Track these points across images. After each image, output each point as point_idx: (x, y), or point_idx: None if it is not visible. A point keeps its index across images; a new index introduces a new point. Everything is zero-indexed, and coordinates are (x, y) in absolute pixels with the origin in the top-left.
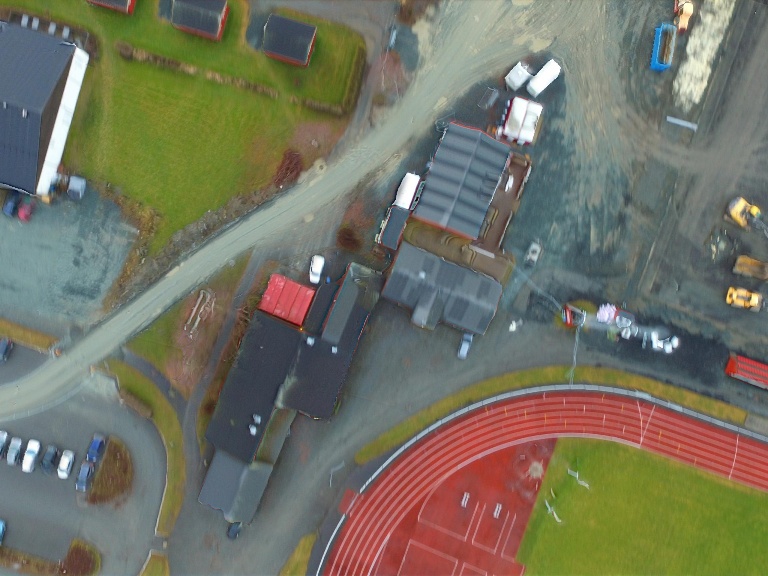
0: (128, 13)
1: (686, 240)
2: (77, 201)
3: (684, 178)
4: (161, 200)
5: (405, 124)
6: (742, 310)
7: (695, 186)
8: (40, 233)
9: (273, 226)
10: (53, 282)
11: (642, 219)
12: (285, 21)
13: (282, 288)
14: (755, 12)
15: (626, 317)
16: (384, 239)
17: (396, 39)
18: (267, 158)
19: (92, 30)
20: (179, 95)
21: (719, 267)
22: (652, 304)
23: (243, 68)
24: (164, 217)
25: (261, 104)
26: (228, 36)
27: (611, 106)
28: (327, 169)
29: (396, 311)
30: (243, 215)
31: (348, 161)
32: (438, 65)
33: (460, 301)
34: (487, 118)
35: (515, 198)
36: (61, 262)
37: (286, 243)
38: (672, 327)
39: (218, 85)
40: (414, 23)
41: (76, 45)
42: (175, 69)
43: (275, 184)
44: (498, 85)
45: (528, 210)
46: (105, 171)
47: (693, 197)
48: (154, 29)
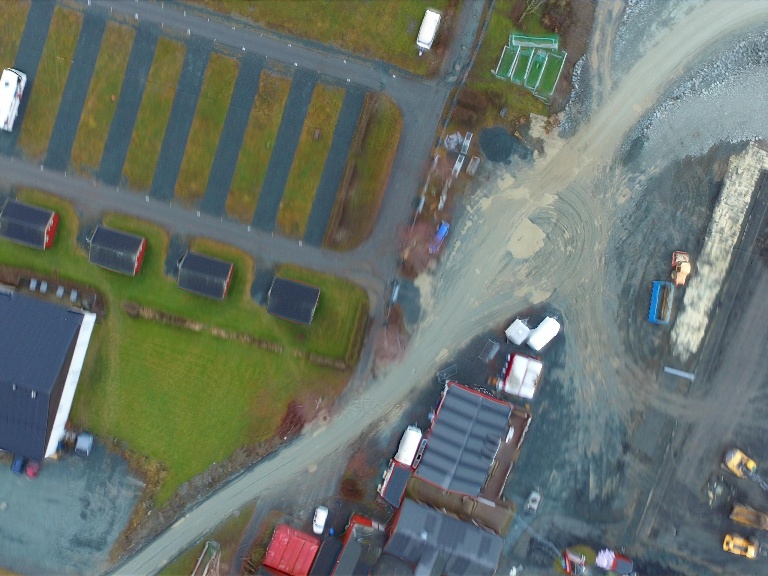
0: (135, 275)
1: (684, 486)
2: (84, 457)
3: (682, 426)
4: (167, 454)
5: (407, 375)
6: (739, 556)
7: (692, 434)
8: (48, 487)
9: (277, 476)
10: (61, 535)
11: (640, 466)
12: (289, 284)
13: (286, 544)
14: (751, 264)
15: (625, 567)
16: (387, 497)
17: (398, 293)
18: (271, 410)
19: (99, 288)
20: (185, 351)
21: (716, 512)
22: (650, 549)
23: (248, 323)
24: (170, 470)
25: (265, 358)
26: (233, 292)
27: (610, 356)
28: (330, 420)
29: (398, 560)
30: (248, 466)
31: (351, 412)
32: (440, 317)
33: (461, 560)
34: (488, 369)
35: (515, 448)
36: (68, 515)
37: (290, 493)
38: (670, 571)
39: (223, 340)
40: (416, 277)
41: (84, 307)
42: (181, 326)
43: (279, 436)
44: (499, 337)
45: (528, 458)
46: (112, 426)
47: (690, 445)
48: (160, 286)
